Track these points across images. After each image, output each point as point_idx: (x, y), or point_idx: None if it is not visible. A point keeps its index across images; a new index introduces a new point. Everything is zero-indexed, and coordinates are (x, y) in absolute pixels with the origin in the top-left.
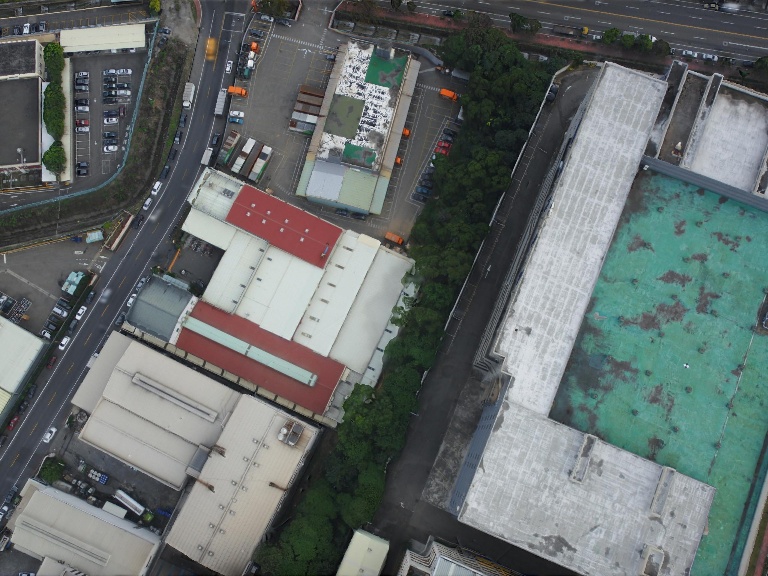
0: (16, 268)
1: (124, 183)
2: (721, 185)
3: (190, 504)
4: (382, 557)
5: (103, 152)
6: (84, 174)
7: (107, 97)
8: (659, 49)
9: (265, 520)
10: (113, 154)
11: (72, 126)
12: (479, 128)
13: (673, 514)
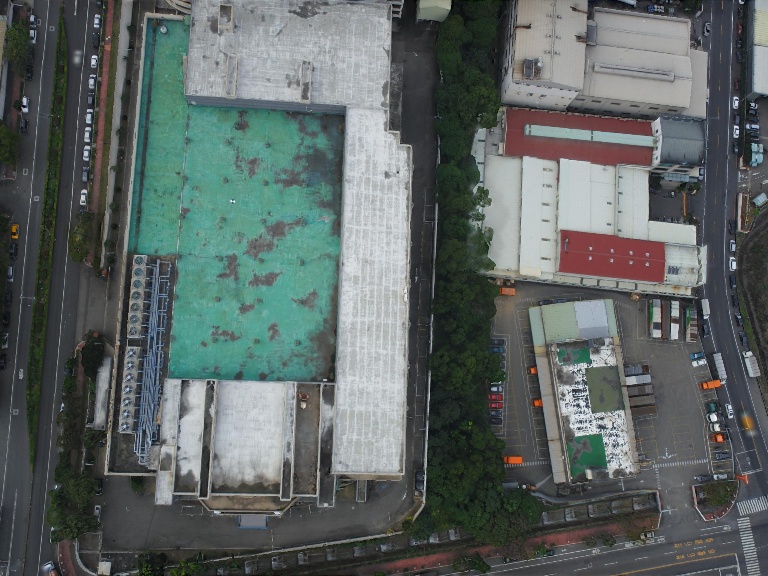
0: None
1: (761, 261)
2: None
3: None
4: None
5: None
6: None
7: None
8: None
9: (522, 1)
10: None
11: None
12: None
13: (217, 64)
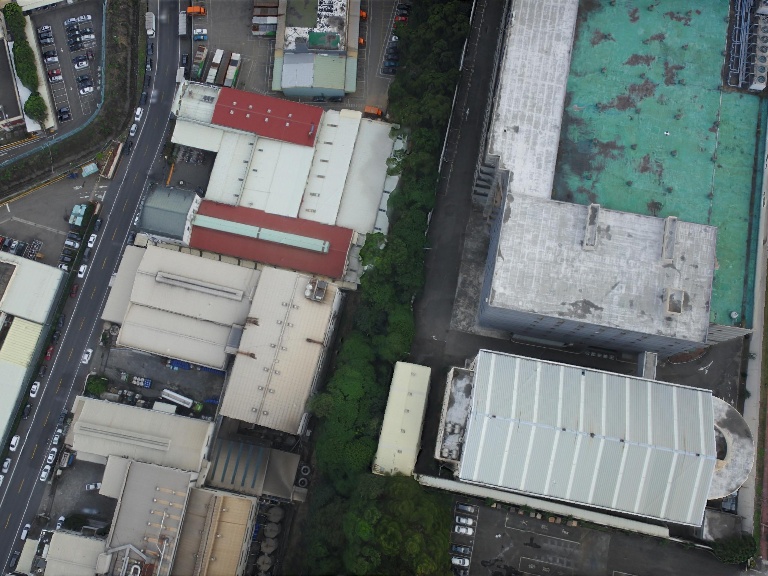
0: (21, 214)
1: (107, 118)
2: None
3: (236, 375)
4: (426, 379)
5: (80, 95)
6: (66, 119)
7: (73, 45)
8: None
9: (309, 374)
10: (90, 95)
11: (45, 78)
12: None
13: (683, 258)
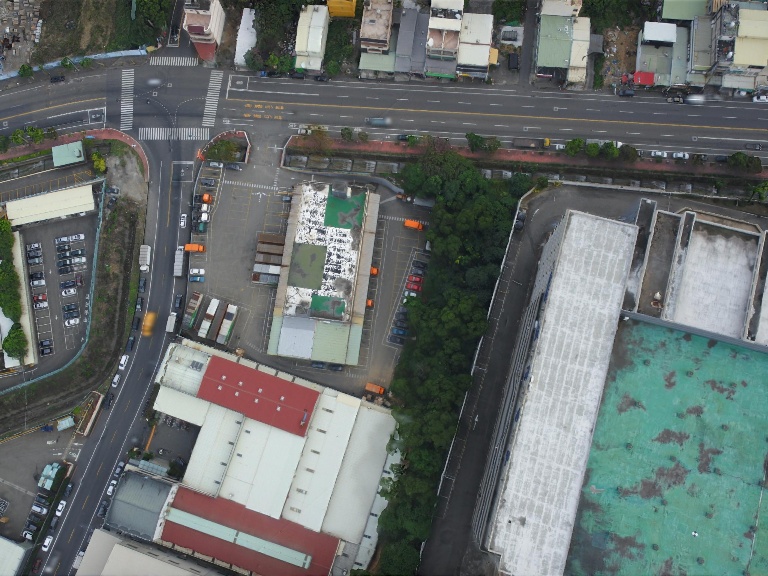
0: None
1: (90, 359)
2: (708, 333)
3: None
4: None
5: (65, 326)
6: (48, 353)
7: (62, 267)
8: (626, 155)
9: None
10: (75, 327)
11: (30, 302)
12: (448, 263)
13: None
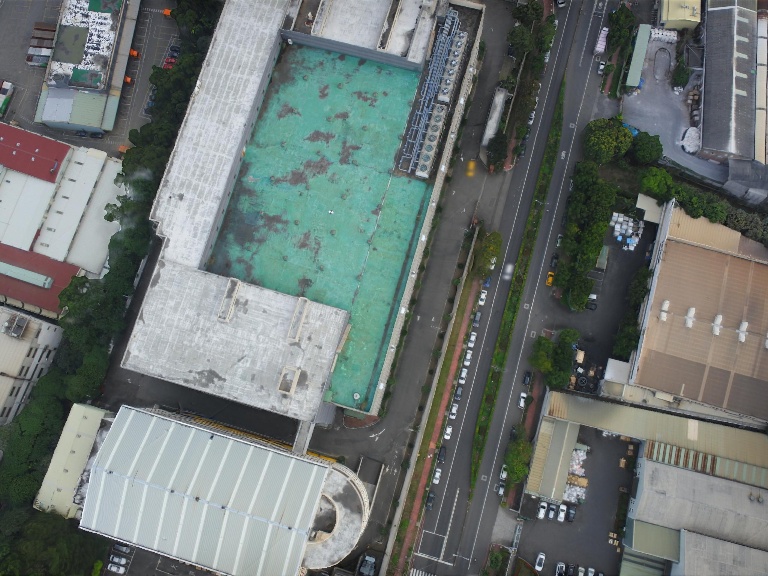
0: None
1: None
2: (351, 47)
3: None
4: (98, 423)
5: None
6: None
7: None
8: None
9: None
10: None
11: None
12: None
13: (310, 338)
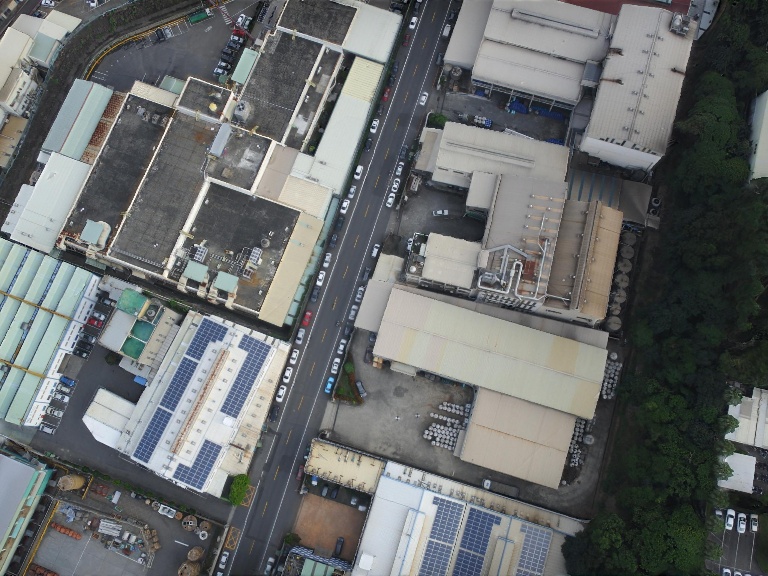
0: None
1: None
2: None
3: (602, 99)
4: None
5: None
6: None
7: None
8: None
9: (675, 101)
10: None
11: None
12: None
13: None
